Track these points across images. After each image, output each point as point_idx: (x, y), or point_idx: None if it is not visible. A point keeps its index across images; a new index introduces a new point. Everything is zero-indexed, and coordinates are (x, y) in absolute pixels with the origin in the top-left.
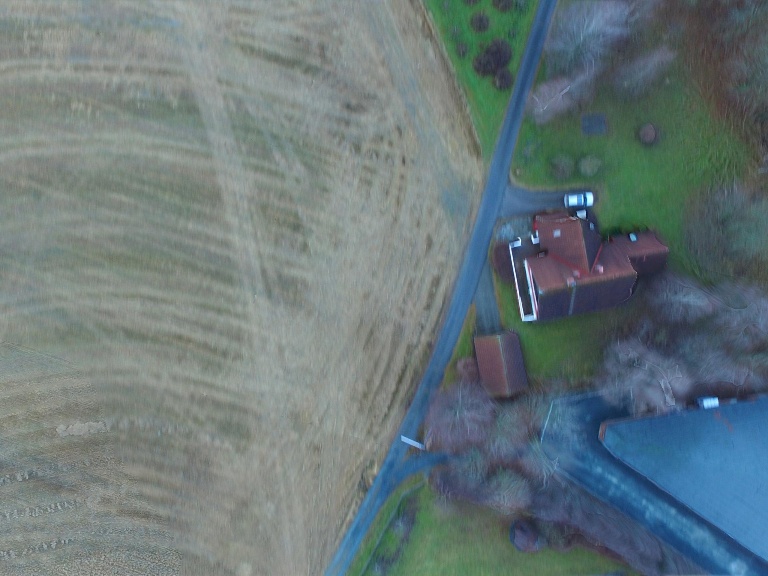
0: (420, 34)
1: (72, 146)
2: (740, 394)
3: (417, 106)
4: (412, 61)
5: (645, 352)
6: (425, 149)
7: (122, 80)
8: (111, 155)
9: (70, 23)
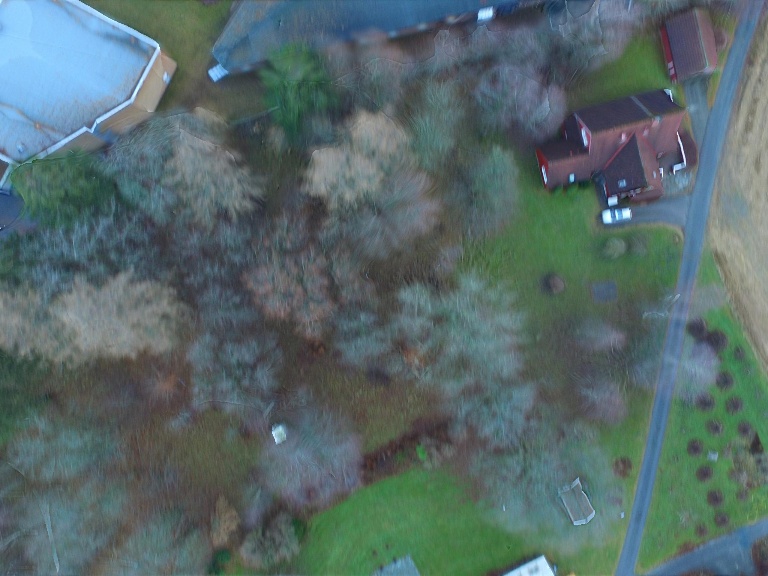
0: None
1: None
2: (450, 26)
3: None
4: None
5: (555, 62)
6: (767, 256)
7: None
8: None
9: None
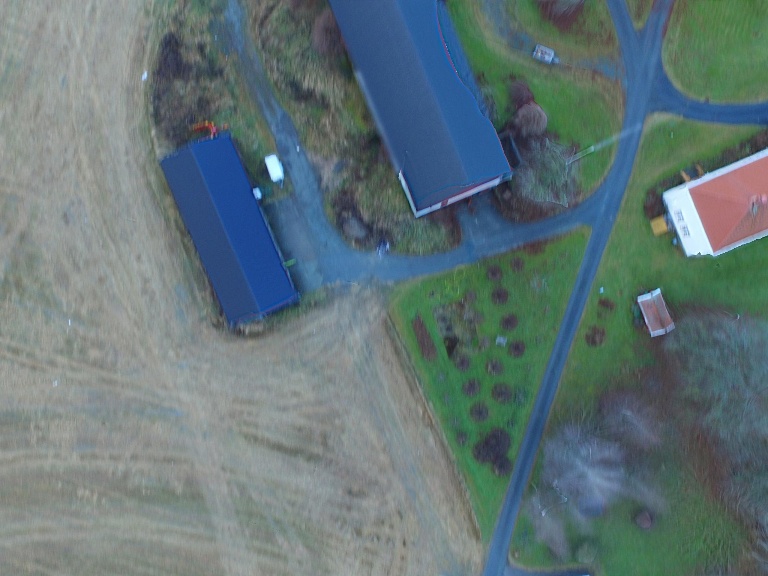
0: (421, 423)
1: (78, 532)
2: None
3: (417, 491)
4: (413, 448)
5: None
6: (425, 531)
7: (127, 468)
8: (117, 540)
9: (76, 413)
